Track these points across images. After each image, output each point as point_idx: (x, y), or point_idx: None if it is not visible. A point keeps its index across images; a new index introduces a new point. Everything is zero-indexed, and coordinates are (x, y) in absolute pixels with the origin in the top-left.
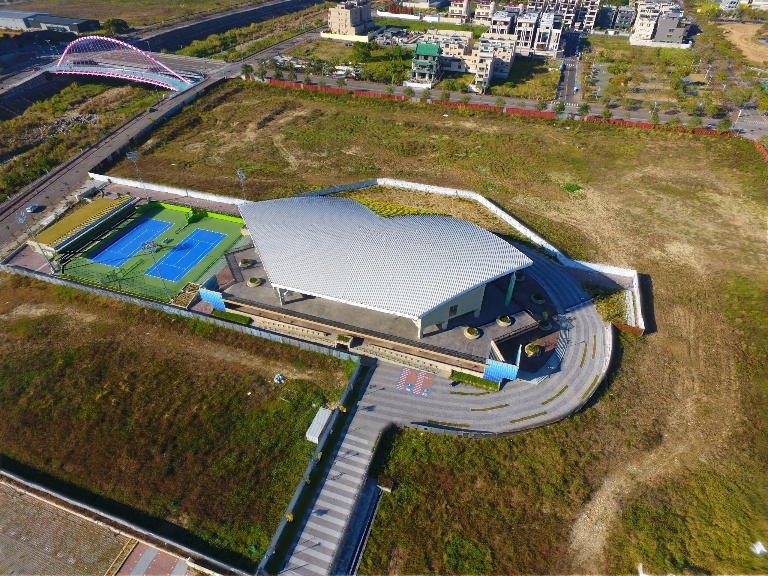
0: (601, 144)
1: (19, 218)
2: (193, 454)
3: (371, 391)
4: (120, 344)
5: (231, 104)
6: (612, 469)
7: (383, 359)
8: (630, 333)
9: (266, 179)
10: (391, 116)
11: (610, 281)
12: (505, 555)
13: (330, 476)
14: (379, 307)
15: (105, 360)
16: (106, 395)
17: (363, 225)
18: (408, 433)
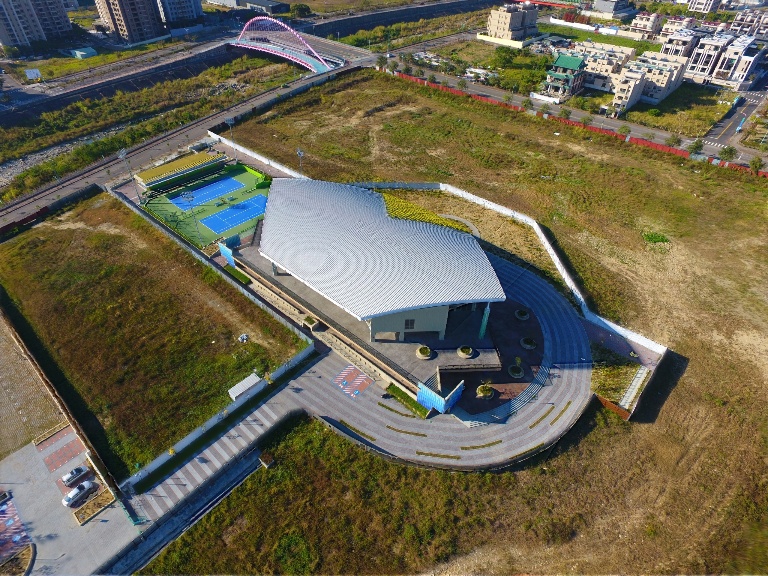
0: (730, 197)
1: (119, 154)
2: (143, 374)
3: (308, 375)
4: (149, 272)
5: (354, 91)
6: (492, 542)
7: (336, 351)
8: (614, 413)
9: (341, 163)
10: (497, 125)
11: (630, 350)
12: (330, 571)
13: (228, 434)
14: (332, 298)
15: (131, 280)
16: (116, 307)
17: (364, 220)
18: (315, 424)
